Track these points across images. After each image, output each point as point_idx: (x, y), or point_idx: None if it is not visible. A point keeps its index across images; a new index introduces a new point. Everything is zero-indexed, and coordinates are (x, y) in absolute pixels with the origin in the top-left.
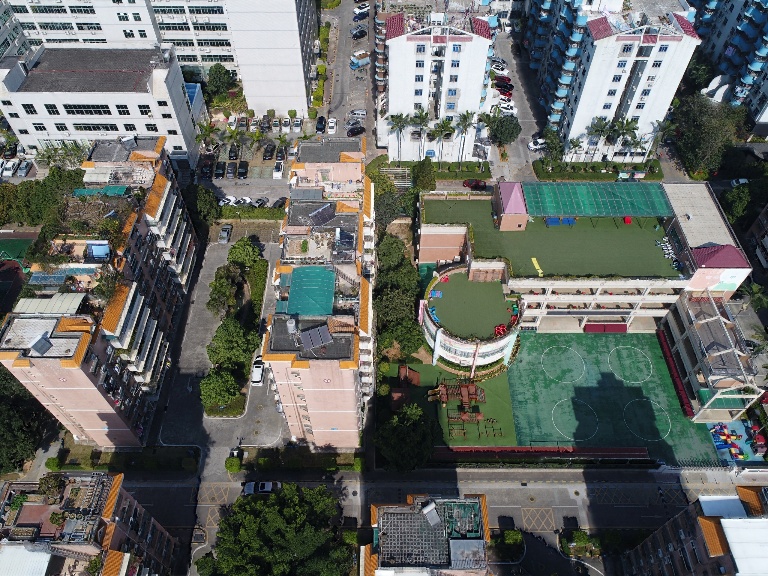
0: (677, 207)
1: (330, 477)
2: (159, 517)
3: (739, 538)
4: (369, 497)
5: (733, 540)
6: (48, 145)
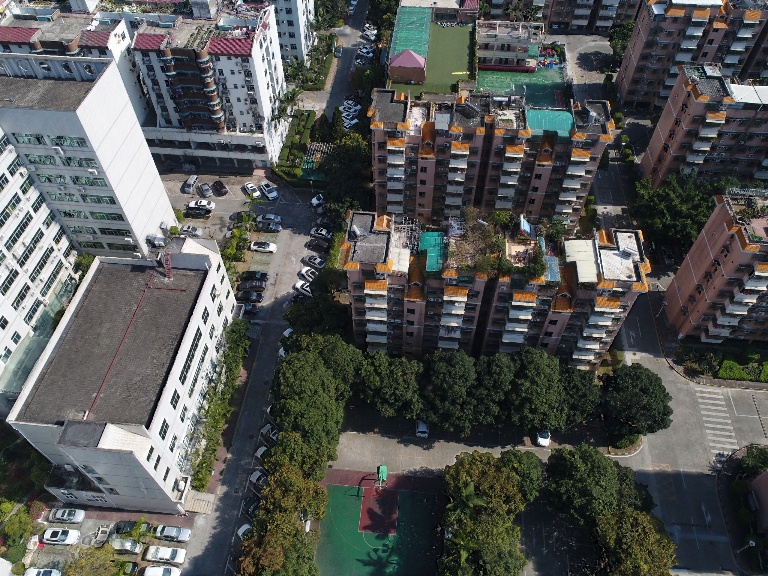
0: (424, 6)
1: (597, 219)
2: (645, 312)
3: (681, 0)
4: (607, 202)
5: (682, 2)
6: (181, 460)
